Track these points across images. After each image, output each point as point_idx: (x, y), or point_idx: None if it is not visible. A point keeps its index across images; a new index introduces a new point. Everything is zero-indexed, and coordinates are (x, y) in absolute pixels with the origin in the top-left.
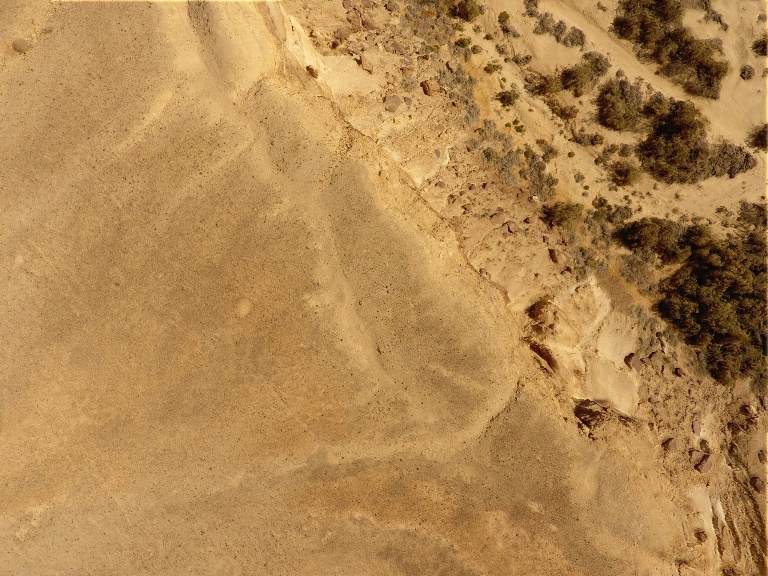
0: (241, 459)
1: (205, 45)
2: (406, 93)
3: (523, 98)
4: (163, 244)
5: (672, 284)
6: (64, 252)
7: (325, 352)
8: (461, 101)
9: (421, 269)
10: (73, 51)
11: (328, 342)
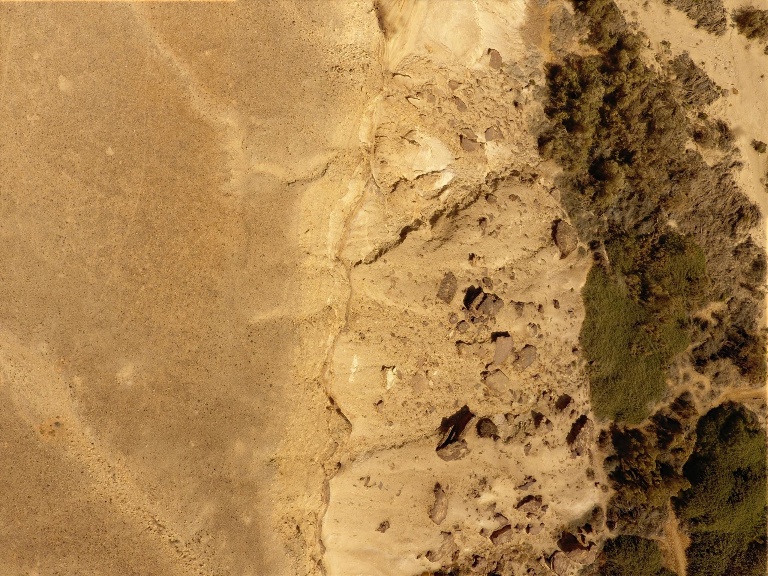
0: None
1: None
2: None
3: None
4: None
5: (578, 63)
6: None
7: None
8: None
9: None
10: None
11: None
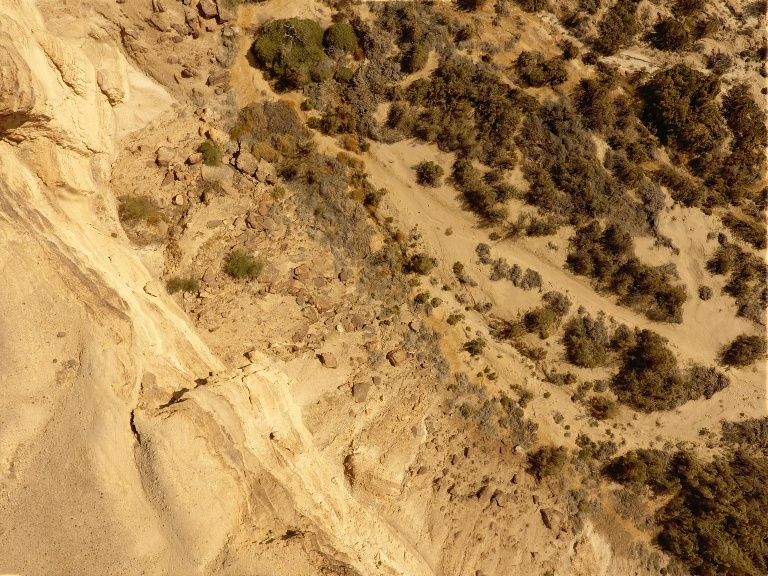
0: None
1: (164, 520)
2: (373, 372)
3: (490, 345)
4: None
5: (667, 513)
6: None
7: None
8: (429, 360)
9: None
10: (28, 554)
11: None
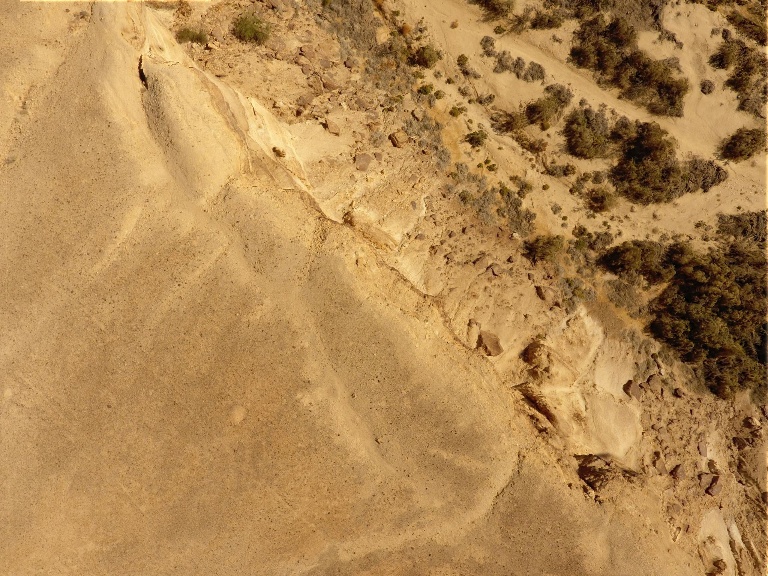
0: (253, 567)
1: (169, 156)
2: (375, 149)
3: (491, 137)
4: (150, 360)
5: (661, 303)
6: (52, 380)
7: (324, 449)
8: (431, 148)
9: (409, 355)
10: (38, 178)
11: (326, 439)
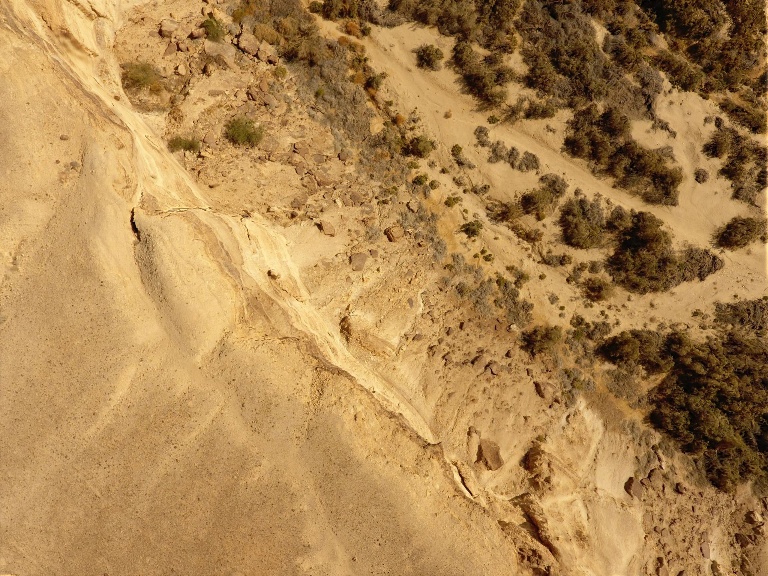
0: None
1: (162, 312)
2: (371, 245)
3: (487, 227)
4: (147, 527)
5: (660, 393)
6: (47, 549)
7: None
8: (426, 240)
9: (410, 517)
10: (30, 339)
11: None
